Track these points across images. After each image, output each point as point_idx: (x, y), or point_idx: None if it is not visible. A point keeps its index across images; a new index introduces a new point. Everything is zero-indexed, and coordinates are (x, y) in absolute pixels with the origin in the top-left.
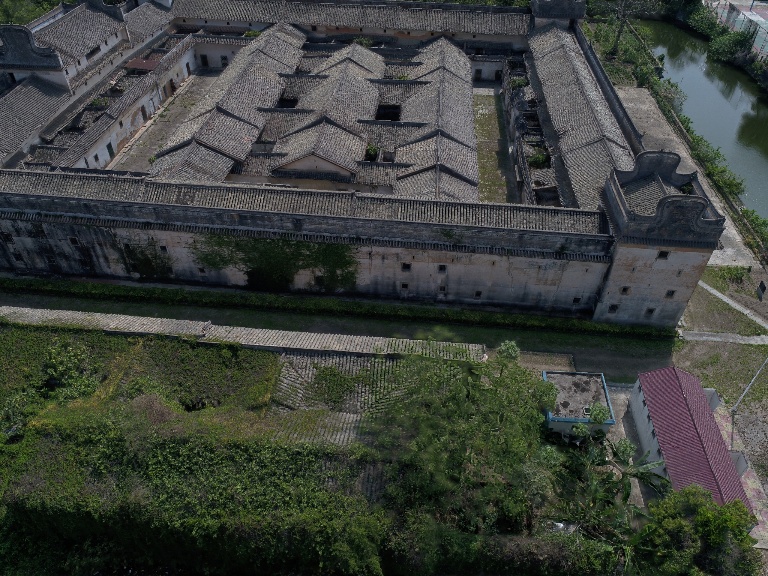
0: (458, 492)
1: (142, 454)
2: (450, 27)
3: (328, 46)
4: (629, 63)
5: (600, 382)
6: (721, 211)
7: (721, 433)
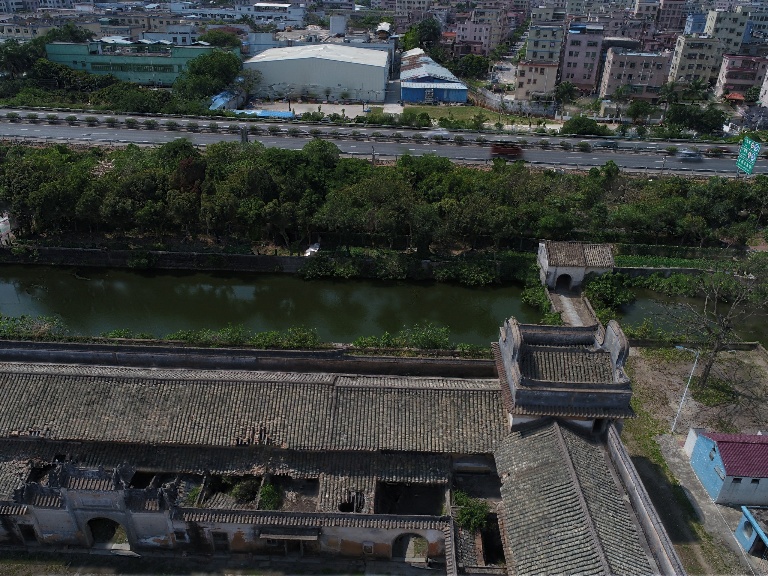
0: None
1: None
2: None
3: None
4: None
5: (758, 511)
6: None
7: None
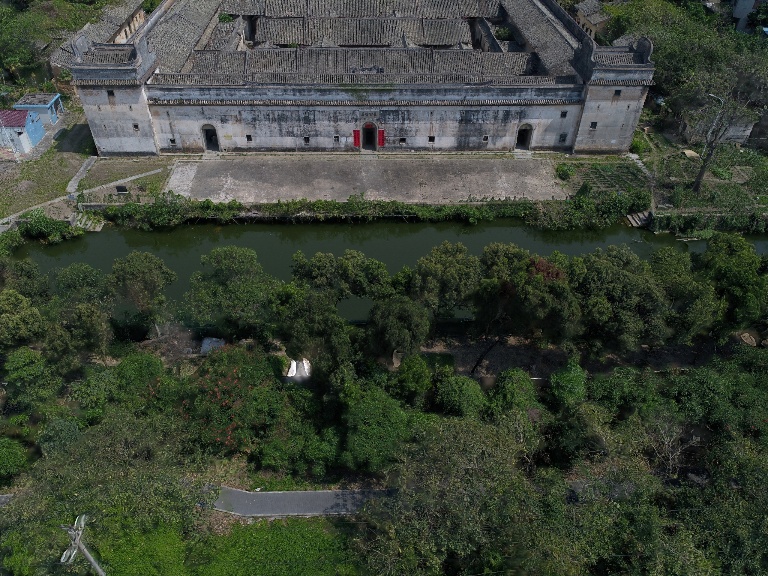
0: (8, 83)
1: (29, 8)
2: (540, 46)
3: (486, 25)
4: (668, 201)
5: None
6: (252, 201)
7: (5, 155)
